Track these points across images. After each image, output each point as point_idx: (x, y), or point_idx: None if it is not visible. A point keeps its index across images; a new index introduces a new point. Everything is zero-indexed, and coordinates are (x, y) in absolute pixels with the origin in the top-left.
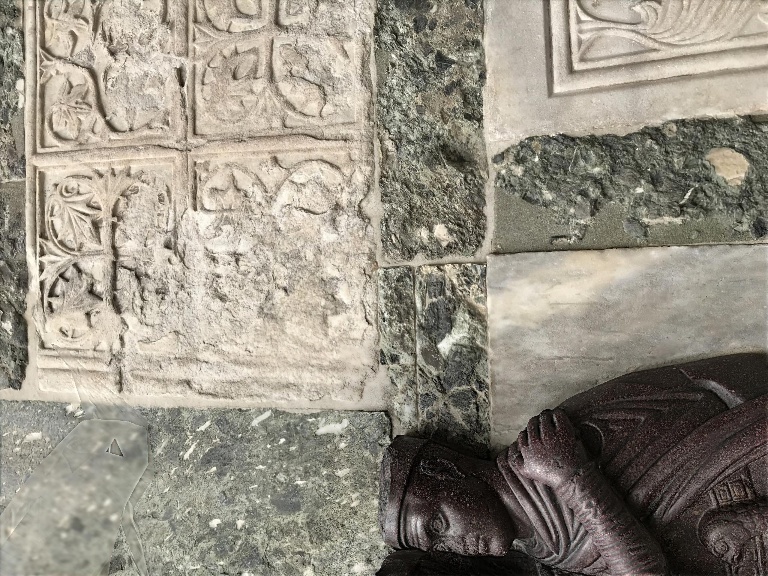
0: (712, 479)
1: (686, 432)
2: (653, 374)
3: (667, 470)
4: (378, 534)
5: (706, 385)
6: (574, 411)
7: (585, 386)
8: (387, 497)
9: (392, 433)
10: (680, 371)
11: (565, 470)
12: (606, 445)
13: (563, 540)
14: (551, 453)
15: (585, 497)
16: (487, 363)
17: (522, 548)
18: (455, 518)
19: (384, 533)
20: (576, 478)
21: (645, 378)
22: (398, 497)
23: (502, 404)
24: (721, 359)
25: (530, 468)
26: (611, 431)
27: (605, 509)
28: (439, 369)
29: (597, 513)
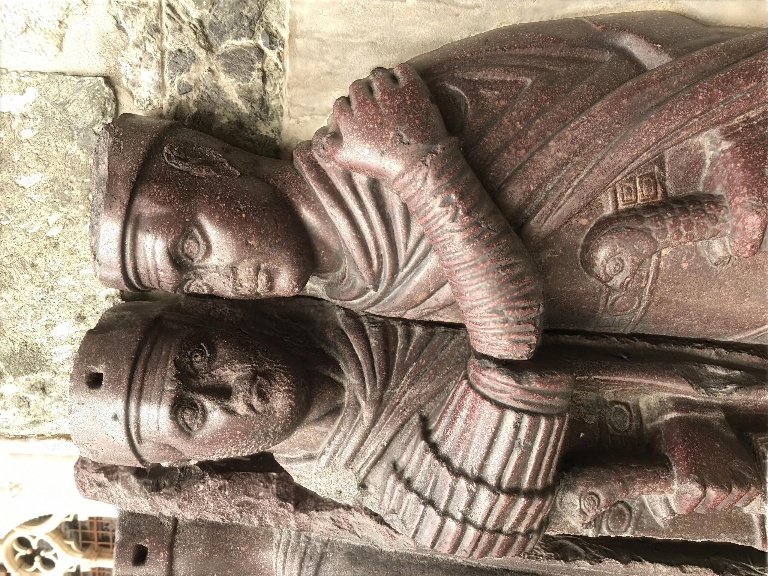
0: (624, 166)
1: (591, 101)
2: (543, 23)
3: (562, 153)
4: (95, 277)
5: (619, 39)
6: (426, 66)
7: (434, 48)
8: (101, 202)
9: (118, 116)
10: (582, 20)
11: (412, 147)
12: (473, 117)
13: (388, 267)
14: (391, 121)
15: (442, 188)
16: (284, 1)
17: (318, 291)
18: (221, 236)
19: (97, 263)
20: (431, 158)
21: (532, 27)
22: (121, 201)
23: (304, 72)
24: (634, 12)
25: (353, 148)
26: (482, 97)
27: (471, 207)
28: (202, 6)
29: (458, 213)
